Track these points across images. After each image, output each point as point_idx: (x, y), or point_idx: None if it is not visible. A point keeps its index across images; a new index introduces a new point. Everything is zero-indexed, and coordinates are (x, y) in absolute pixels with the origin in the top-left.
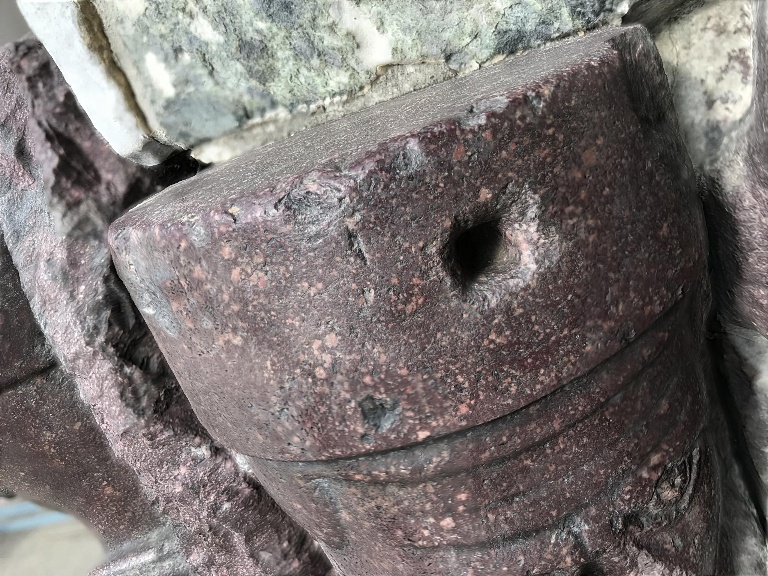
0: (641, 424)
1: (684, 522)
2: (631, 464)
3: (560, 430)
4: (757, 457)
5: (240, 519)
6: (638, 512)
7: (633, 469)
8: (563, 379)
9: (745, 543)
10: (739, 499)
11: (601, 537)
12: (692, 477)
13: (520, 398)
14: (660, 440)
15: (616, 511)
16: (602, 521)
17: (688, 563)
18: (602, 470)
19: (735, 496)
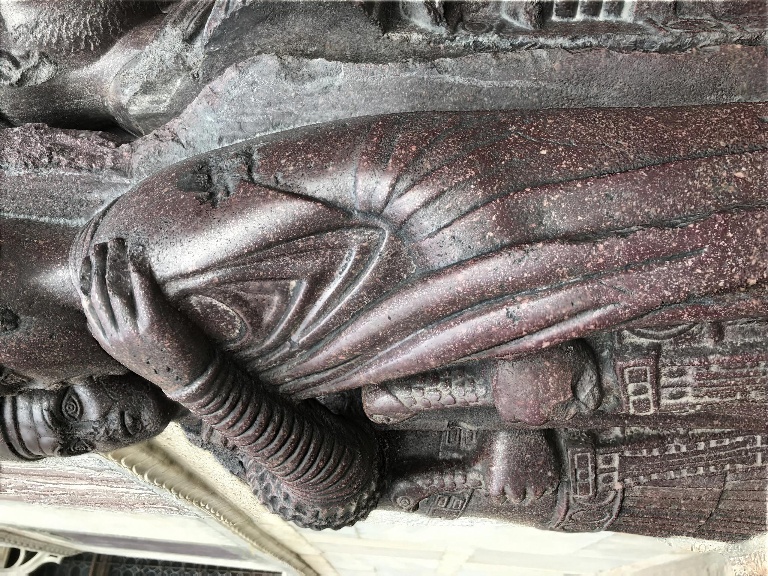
0: None
1: None
2: None
3: None
4: None
5: None
6: None
7: None
8: None
9: None
10: None
11: None
12: None
13: None
14: None
15: None
16: None
17: None
18: None
19: None
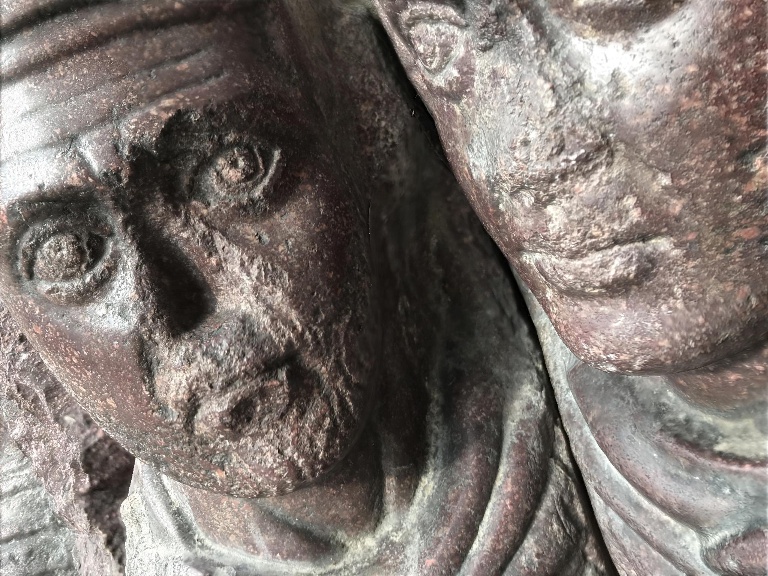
0: (149, 70)
1: (274, 222)
2: (137, 100)
3: (55, 56)
4: (529, 303)
5: (39, 374)
6: (205, 192)
7: (141, 106)
8: (38, 0)
9: (520, 391)
10: (525, 356)
11: (105, 158)
12: (270, 173)
13: (0, 13)
14: (173, 88)
15: (122, 139)
16: (105, 143)
17: (276, 258)
18: (104, 99)
19: (521, 354)
